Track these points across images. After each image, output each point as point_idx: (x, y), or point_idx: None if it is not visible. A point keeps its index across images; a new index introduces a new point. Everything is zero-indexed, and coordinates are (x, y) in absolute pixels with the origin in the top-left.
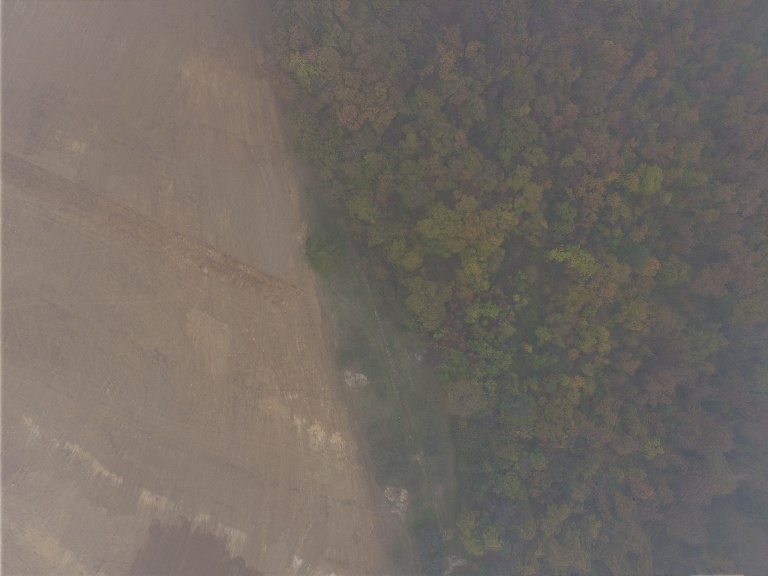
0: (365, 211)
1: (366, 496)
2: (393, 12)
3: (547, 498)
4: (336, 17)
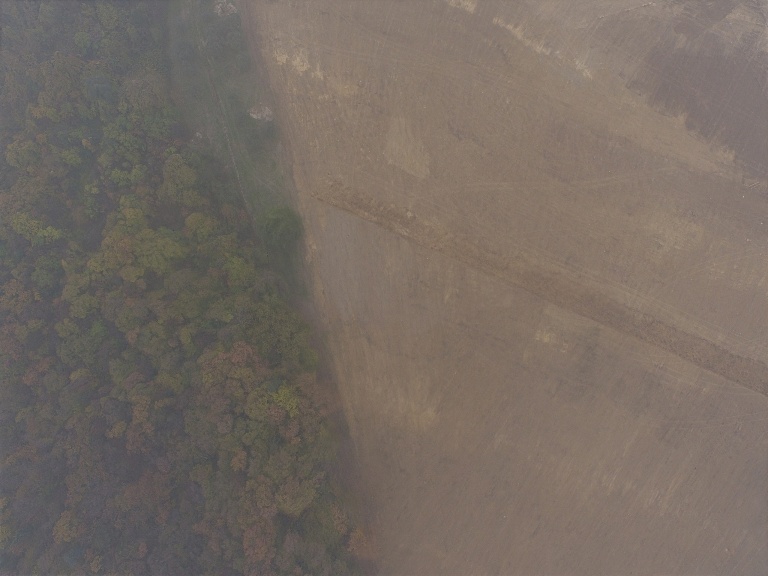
0: (234, 264)
1: (255, 8)
2: (195, 463)
3: (78, 8)
4: (246, 450)
